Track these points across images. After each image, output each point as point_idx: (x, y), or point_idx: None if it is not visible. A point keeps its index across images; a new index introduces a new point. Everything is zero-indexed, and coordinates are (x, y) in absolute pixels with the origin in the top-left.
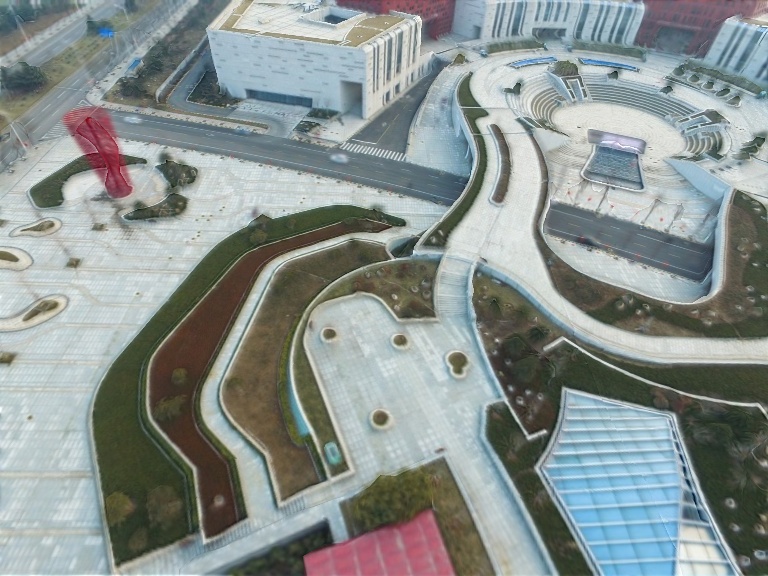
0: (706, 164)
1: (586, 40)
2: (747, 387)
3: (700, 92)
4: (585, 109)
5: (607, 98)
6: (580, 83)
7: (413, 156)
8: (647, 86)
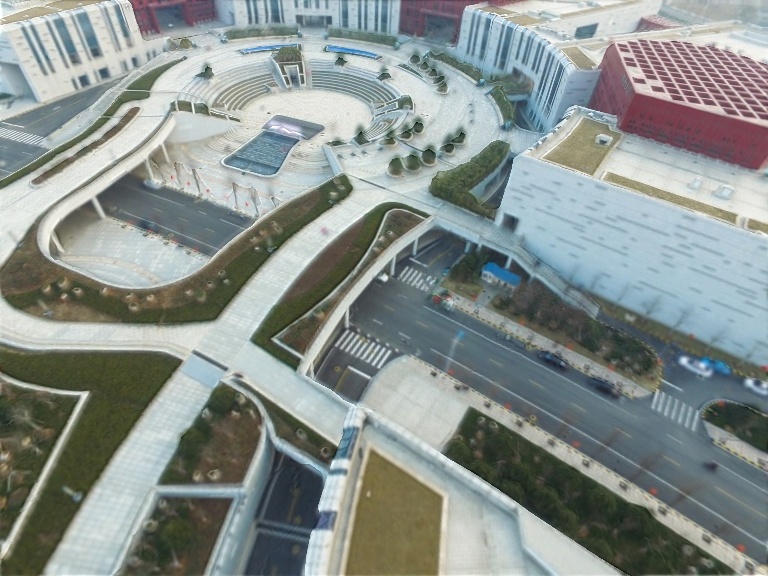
0: (343, 149)
1: (352, 28)
2: (100, 374)
3: (421, 79)
4: (297, 95)
5: (328, 85)
6: (299, 69)
7: (52, 140)
8: (370, 73)
